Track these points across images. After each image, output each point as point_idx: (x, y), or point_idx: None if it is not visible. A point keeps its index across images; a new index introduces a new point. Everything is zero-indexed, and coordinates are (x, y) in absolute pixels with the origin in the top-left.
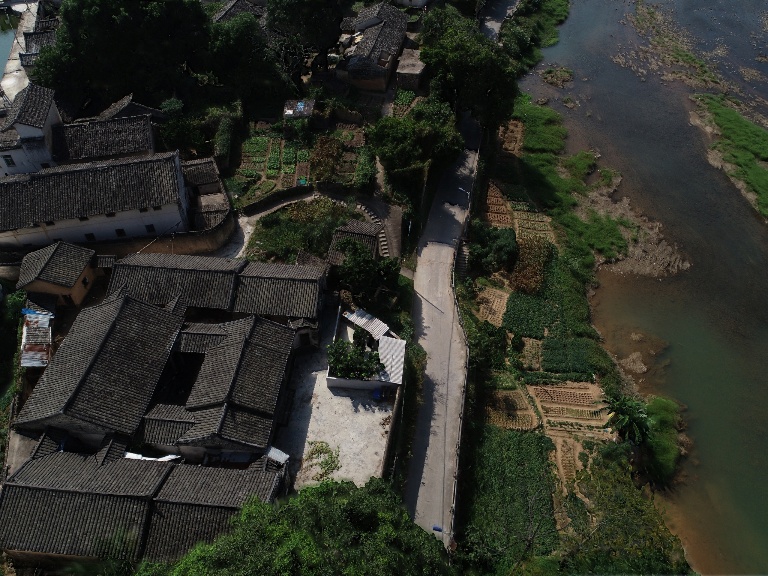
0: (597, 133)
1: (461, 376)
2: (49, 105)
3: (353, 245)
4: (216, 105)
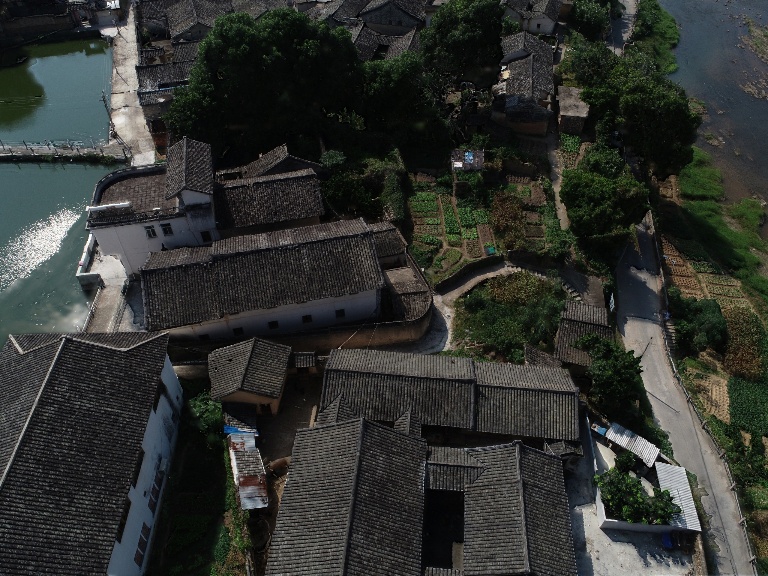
0: (754, 176)
1: (731, 501)
2: (210, 164)
3: (606, 346)
4: (367, 153)
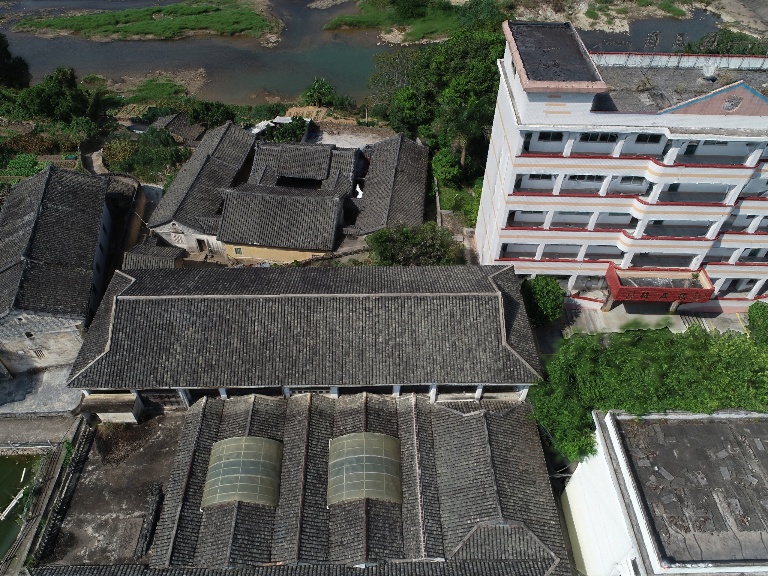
0: None
1: None
2: None
3: (203, 104)
4: None
